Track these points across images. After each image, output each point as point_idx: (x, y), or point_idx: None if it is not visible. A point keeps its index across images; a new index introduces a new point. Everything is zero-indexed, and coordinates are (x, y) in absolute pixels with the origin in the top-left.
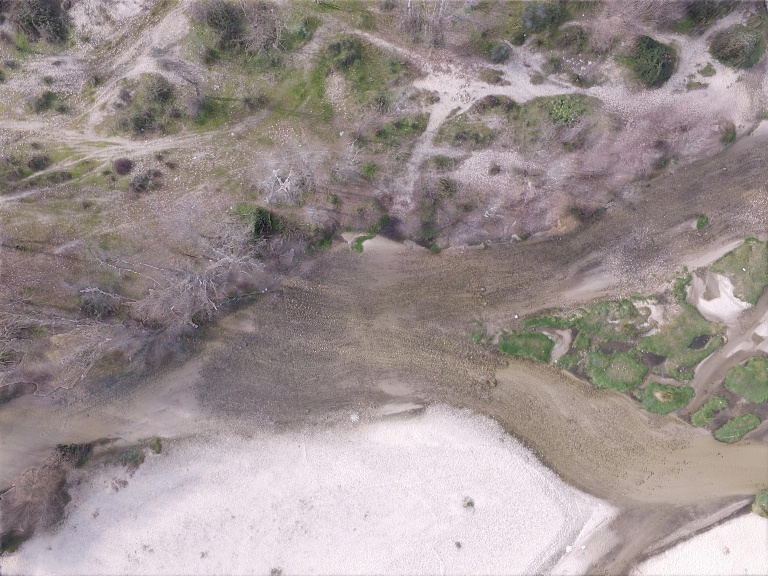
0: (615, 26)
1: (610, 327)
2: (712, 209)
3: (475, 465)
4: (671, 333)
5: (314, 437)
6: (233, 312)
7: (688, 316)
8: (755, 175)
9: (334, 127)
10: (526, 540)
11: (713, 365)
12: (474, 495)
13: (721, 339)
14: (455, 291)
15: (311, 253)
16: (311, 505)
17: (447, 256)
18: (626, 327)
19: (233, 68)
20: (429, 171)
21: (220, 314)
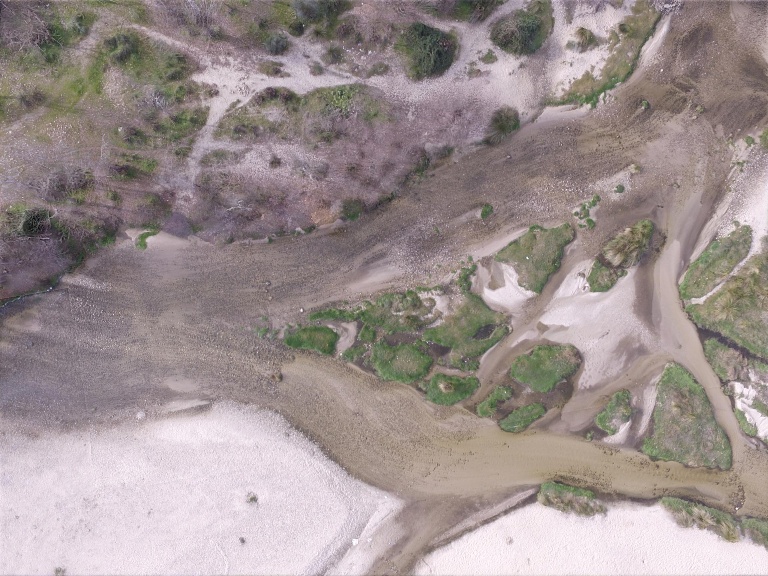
0: (394, 14)
1: (394, 319)
2: (497, 198)
3: (259, 460)
4: (455, 324)
5: (100, 435)
6: (19, 312)
7: (472, 306)
8: (539, 162)
9: (113, 123)
10: (310, 534)
11: (498, 355)
12: (258, 490)
13: (506, 329)
14: (240, 286)
15: (95, 251)
16: (95, 503)
17: (232, 251)
18: (408, 318)
19: (9, 65)
20: (210, 165)
21: (6, 314)
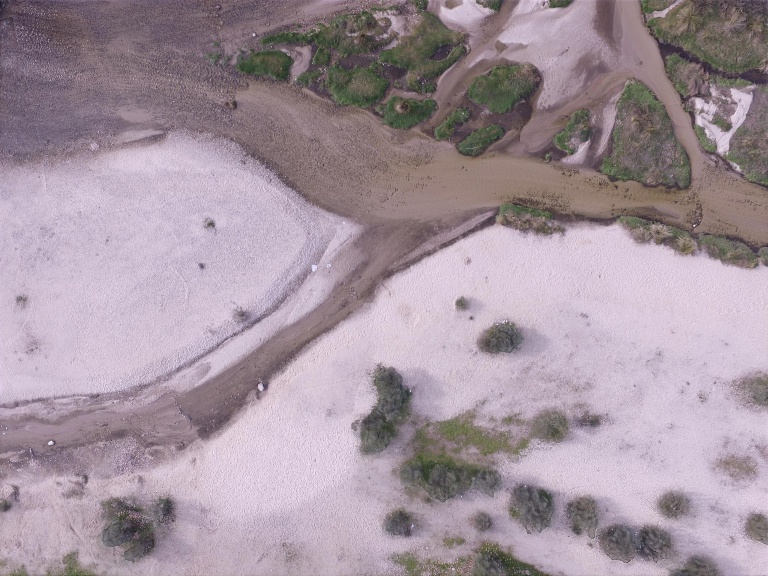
0: None
1: (349, 40)
2: None
3: (215, 187)
4: (411, 43)
5: (54, 168)
6: None
7: (428, 25)
8: None
9: None
10: (269, 259)
11: (456, 76)
12: (215, 216)
13: (463, 48)
14: (190, 11)
15: None
16: (52, 232)
17: None
18: (363, 37)
19: None
20: None
21: None
